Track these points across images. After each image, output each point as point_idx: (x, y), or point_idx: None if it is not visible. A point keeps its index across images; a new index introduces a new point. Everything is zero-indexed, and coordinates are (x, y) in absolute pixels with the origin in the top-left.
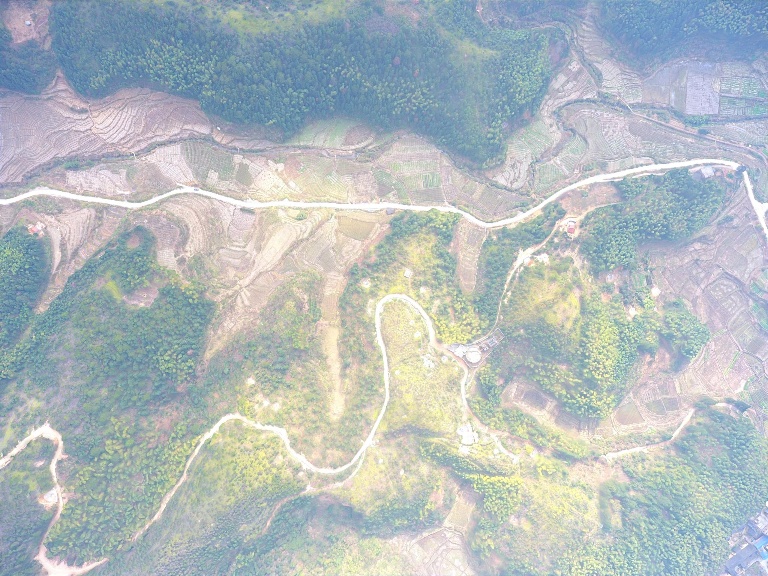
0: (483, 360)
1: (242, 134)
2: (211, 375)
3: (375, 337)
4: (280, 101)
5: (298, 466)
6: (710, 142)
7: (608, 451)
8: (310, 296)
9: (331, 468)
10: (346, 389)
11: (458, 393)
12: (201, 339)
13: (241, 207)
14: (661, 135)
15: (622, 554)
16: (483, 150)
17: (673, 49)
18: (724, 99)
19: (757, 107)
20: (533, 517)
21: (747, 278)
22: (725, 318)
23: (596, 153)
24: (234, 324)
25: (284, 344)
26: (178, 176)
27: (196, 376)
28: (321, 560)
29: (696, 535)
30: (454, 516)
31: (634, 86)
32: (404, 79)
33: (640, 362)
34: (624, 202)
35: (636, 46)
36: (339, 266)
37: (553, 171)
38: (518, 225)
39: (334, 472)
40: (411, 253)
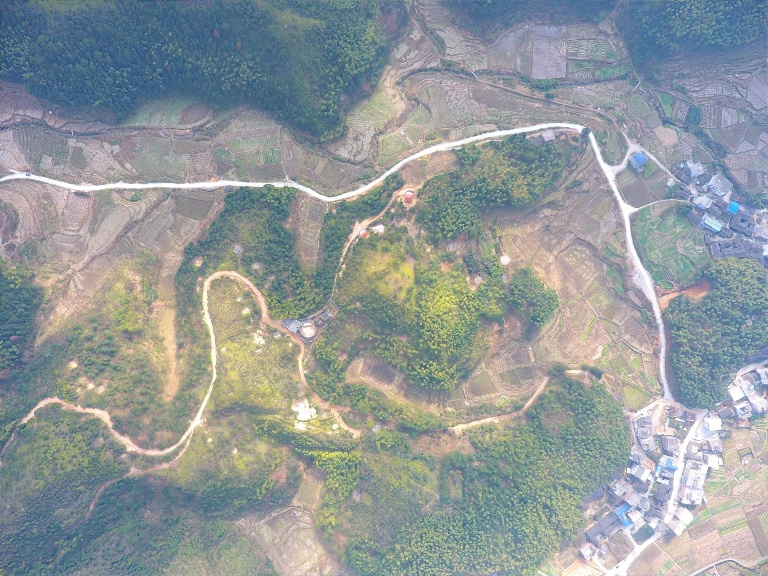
0: (318, 335)
1: (74, 117)
2: (37, 360)
3: (203, 315)
4: (102, 81)
5: (119, 448)
6: (558, 106)
7: (457, 423)
8: (143, 277)
9: (158, 449)
10: (180, 370)
11: (293, 369)
12: (28, 325)
13: (75, 191)
14: (507, 101)
15: (460, 525)
16: (320, 123)
17: (514, 13)
18: (571, 62)
19: (606, 69)
20: (372, 491)
21: (600, 243)
22: (579, 284)
23: (440, 122)
24: (67, 309)
25: (113, 326)
26: (11, 162)
27: (23, 362)
28: (152, 543)
29: (541, 503)
30: (303, 495)
31: (479, 53)
32: (228, 53)
33: (487, 331)
34: (463, 169)
35: (473, 11)
36: (177, 246)
37: (396, 142)
38: (358, 198)
39: (161, 453)
40: (241, 229)
